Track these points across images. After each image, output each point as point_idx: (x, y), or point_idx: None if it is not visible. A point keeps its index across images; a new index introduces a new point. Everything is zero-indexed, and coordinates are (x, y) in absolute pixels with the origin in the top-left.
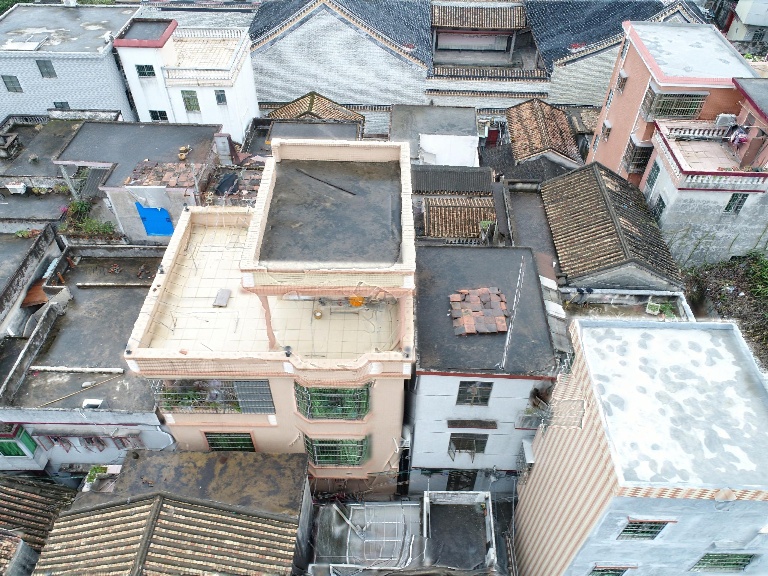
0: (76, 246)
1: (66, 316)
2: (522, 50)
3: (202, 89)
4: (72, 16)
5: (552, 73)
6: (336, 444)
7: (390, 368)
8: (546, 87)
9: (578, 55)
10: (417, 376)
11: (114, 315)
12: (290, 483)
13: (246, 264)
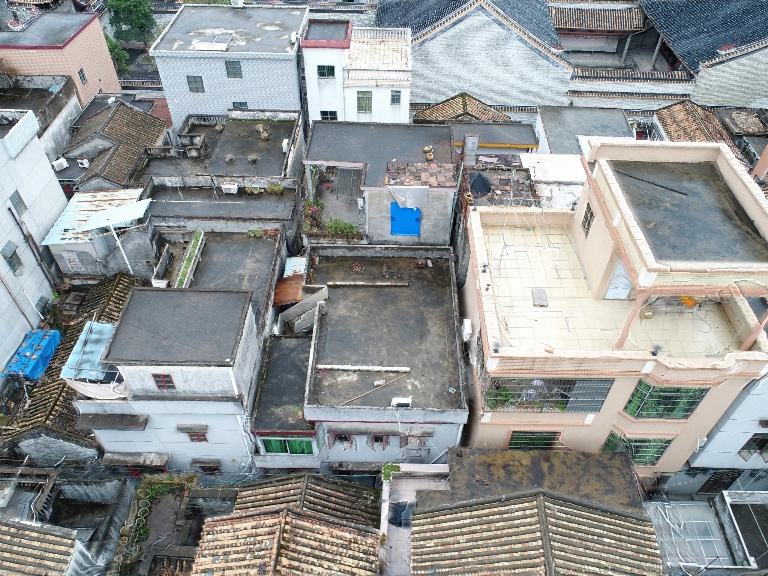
0: (318, 245)
1: (329, 315)
2: (632, 52)
3: (379, 90)
4: (244, 17)
5: (698, 75)
6: (649, 443)
7: (752, 367)
8: (689, 89)
9: (728, 57)
10: (766, 375)
11: (376, 314)
12: (622, 482)
13: (652, 263)
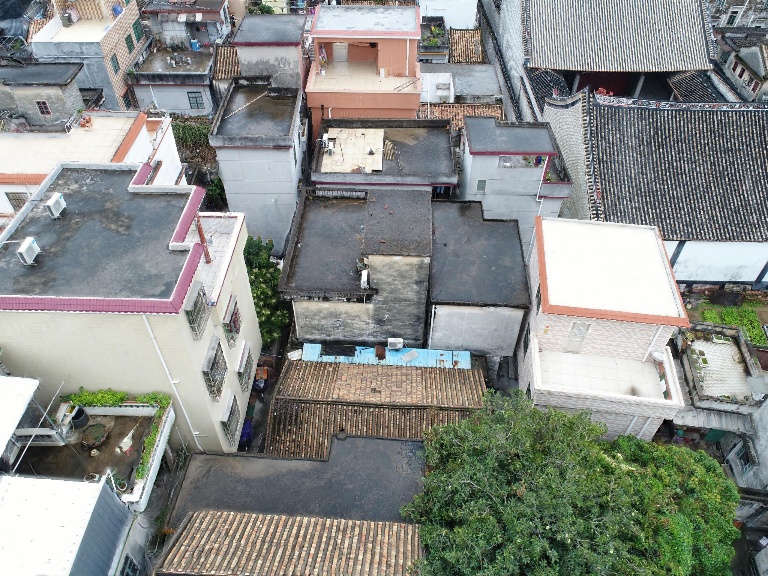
0: None
1: None
2: None
3: None
4: None
5: (544, 108)
6: None
7: None
8: None
9: None
10: None
11: None
12: None
13: None
